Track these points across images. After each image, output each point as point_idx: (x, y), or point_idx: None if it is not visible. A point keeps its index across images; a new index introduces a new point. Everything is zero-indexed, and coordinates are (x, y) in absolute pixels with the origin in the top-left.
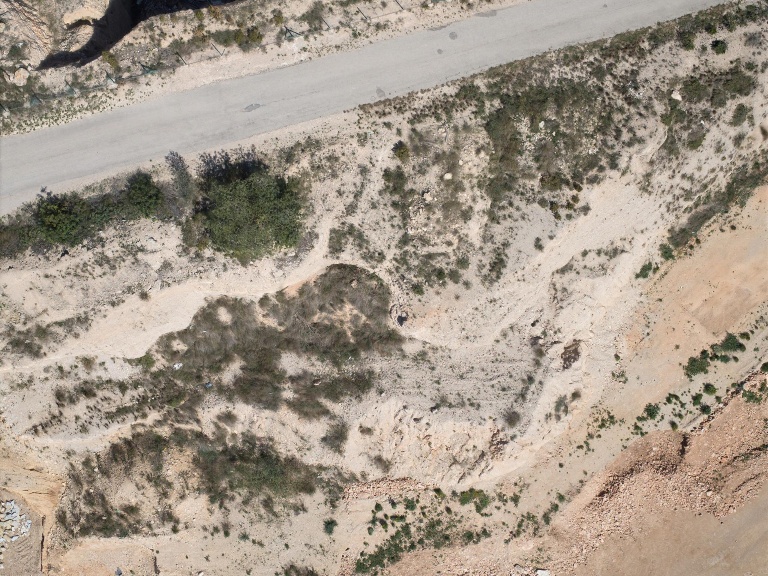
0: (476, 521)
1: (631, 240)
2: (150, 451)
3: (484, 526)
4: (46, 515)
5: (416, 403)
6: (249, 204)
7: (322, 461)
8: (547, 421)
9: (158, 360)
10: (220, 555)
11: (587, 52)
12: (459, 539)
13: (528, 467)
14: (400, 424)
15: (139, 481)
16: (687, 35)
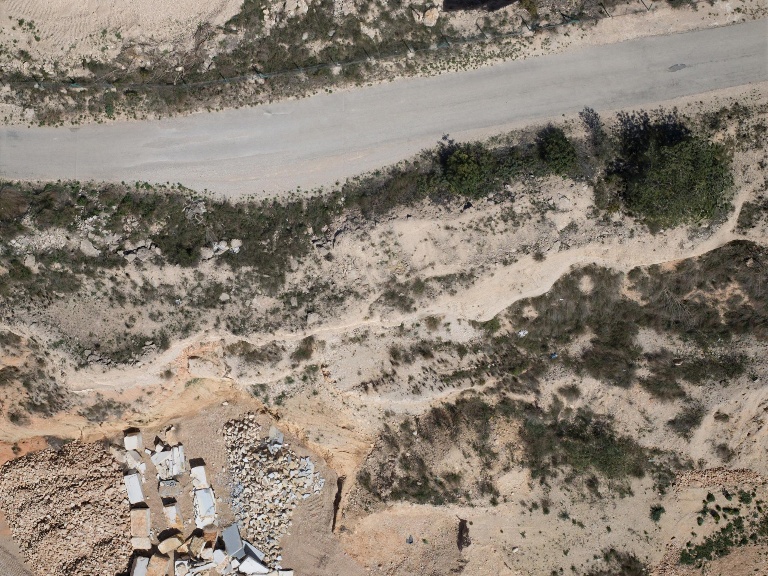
0: None
1: None
2: (476, 419)
3: None
4: (347, 475)
5: None
6: (694, 168)
7: (660, 444)
8: None
9: (504, 325)
10: (537, 532)
11: None
12: None
13: None
14: (764, 413)
15: (466, 449)
16: None
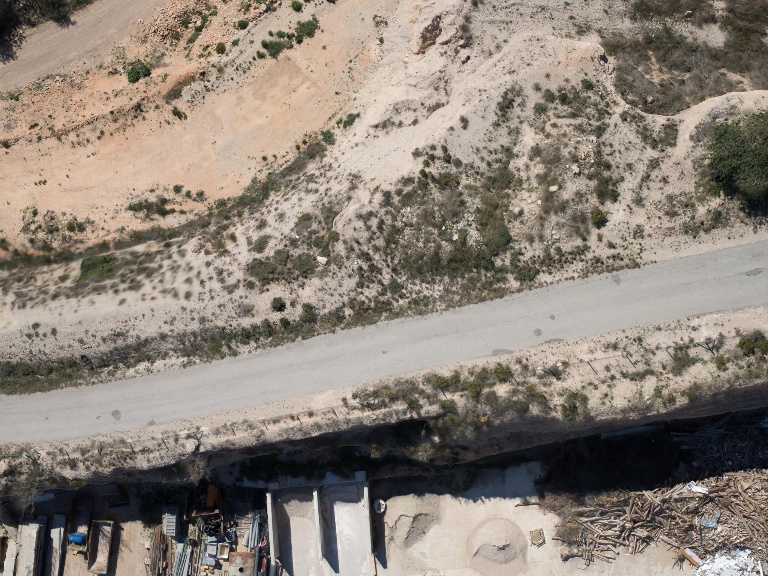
0: None
1: (368, 136)
2: None
3: None
4: None
5: None
6: None
7: None
8: None
9: None
10: None
11: (405, 308)
12: None
13: None
14: None
15: None
16: (309, 317)
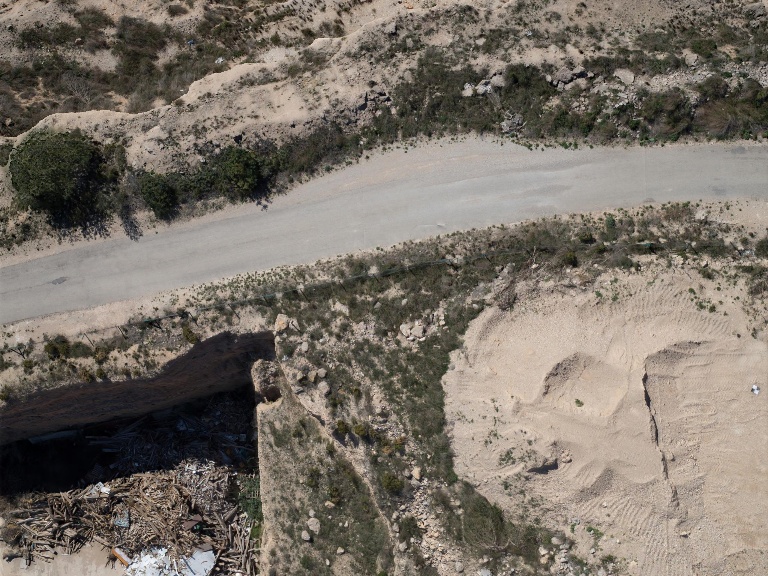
0: None
1: None
2: None
3: None
4: None
5: None
6: None
7: None
8: None
9: None
10: None
11: None
12: None
13: None
14: (8, 3)
15: None
16: None
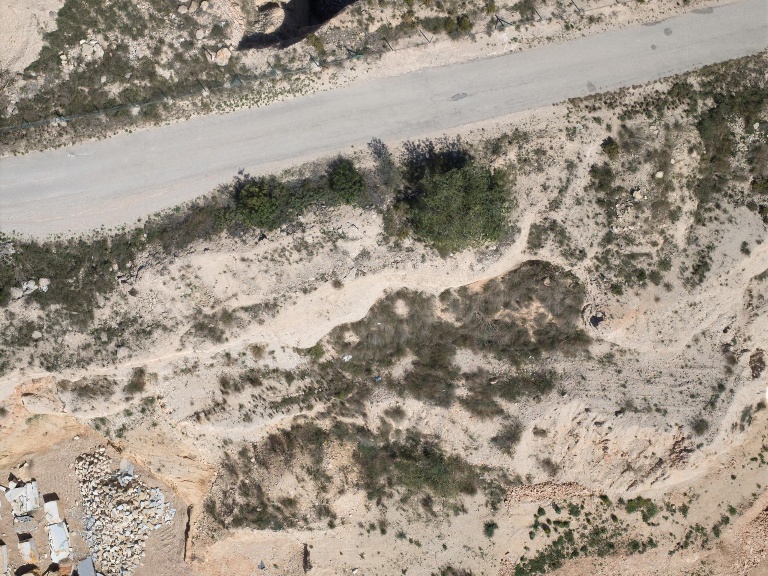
0: (642, 530)
1: None
2: (310, 443)
3: (651, 536)
4: (194, 504)
5: (600, 406)
6: (465, 194)
7: (488, 462)
8: (733, 431)
9: (328, 351)
10: (375, 553)
11: None
12: (624, 548)
13: (699, 477)
14: (578, 427)
15: (299, 473)
16: None
